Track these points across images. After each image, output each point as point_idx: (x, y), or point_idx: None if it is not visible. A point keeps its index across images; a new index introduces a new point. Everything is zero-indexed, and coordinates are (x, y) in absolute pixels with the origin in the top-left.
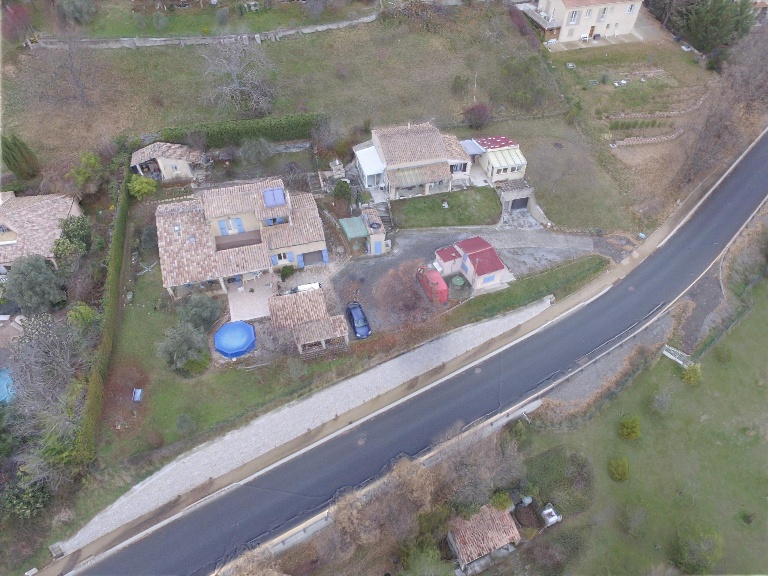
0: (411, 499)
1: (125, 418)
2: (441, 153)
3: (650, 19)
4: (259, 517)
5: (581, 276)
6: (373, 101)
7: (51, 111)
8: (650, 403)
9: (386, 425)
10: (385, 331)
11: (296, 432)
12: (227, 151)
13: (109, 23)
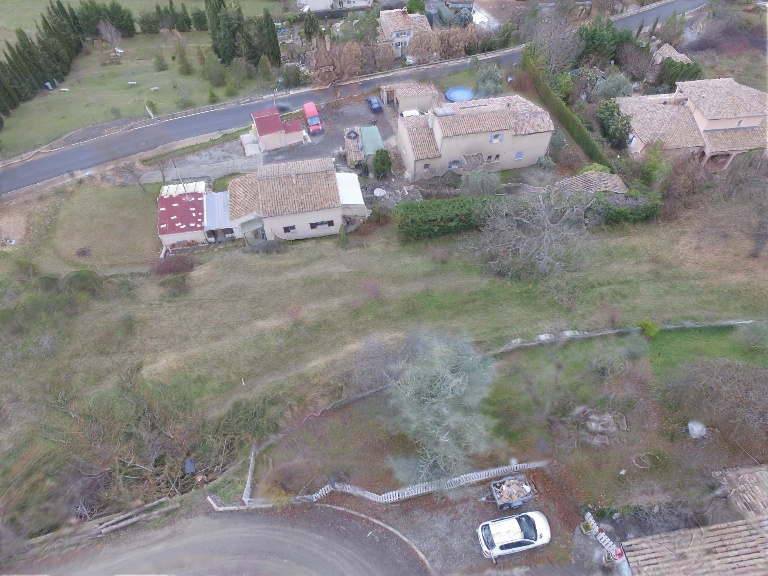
0: None
1: None
2: (265, 166)
3: None
4: None
5: None
6: (329, 268)
7: None
8: (191, 102)
9: None
10: None
11: None
12: None
13: None
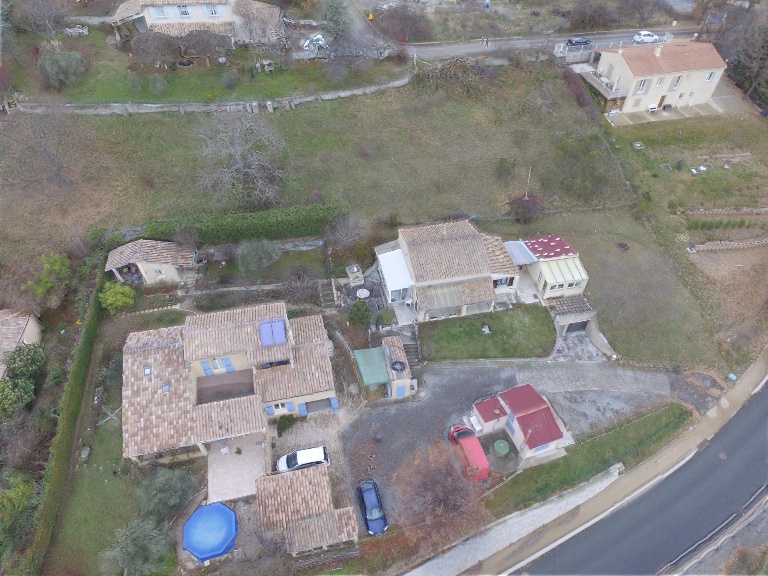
0: None
1: None
2: (483, 267)
3: (729, 86)
4: None
5: (657, 435)
6: (401, 186)
7: (23, 191)
8: None
9: None
10: (406, 523)
11: None
12: (224, 249)
13: (100, 84)
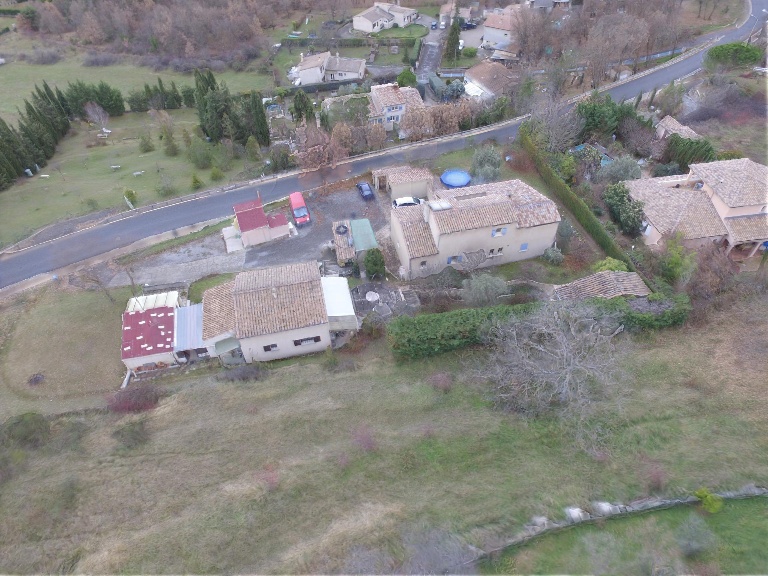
0: None
1: None
2: (244, 275)
3: None
4: (425, 155)
5: None
6: (314, 404)
7: None
8: (174, 189)
9: None
10: None
11: None
12: None
13: None
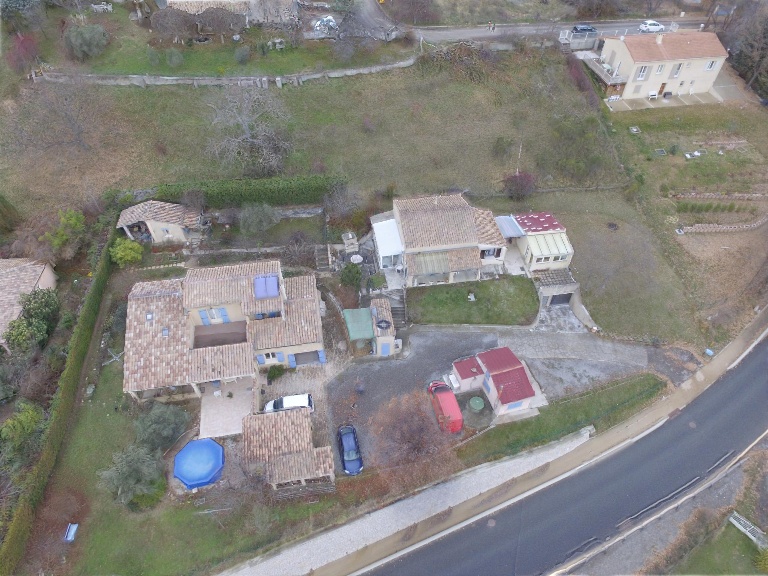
0: None
1: (51, 564)
2: (471, 237)
3: (732, 76)
4: None
5: (630, 402)
6: (400, 161)
7: (45, 154)
8: None
9: None
10: (381, 466)
11: None
12: (228, 213)
13: (120, 57)
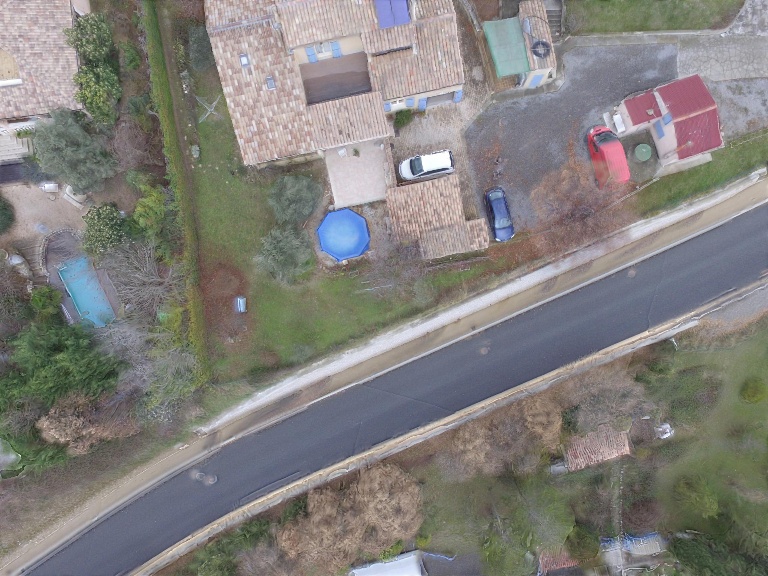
0: (539, 440)
1: (237, 333)
2: None
3: None
4: (381, 418)
5: None
6: None
7: None
8: None
9: (513, 334)
10: (531, 231)
11: (415, 337)
12: None
13: None
